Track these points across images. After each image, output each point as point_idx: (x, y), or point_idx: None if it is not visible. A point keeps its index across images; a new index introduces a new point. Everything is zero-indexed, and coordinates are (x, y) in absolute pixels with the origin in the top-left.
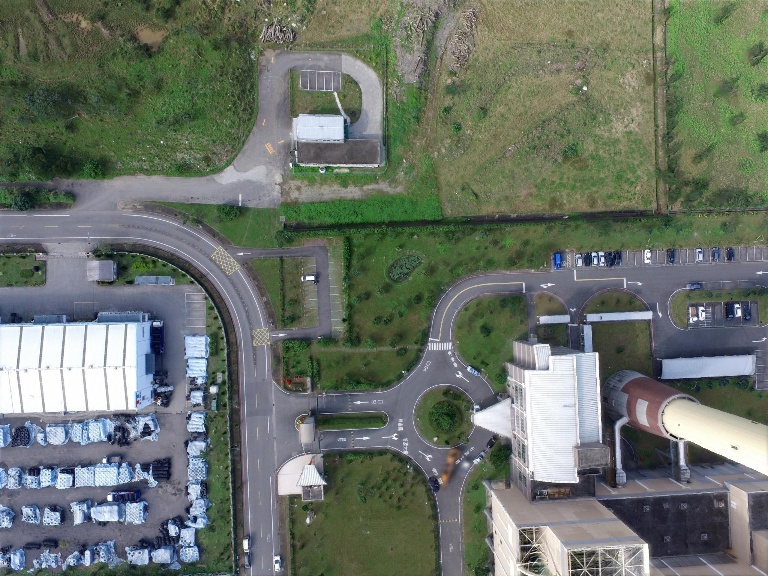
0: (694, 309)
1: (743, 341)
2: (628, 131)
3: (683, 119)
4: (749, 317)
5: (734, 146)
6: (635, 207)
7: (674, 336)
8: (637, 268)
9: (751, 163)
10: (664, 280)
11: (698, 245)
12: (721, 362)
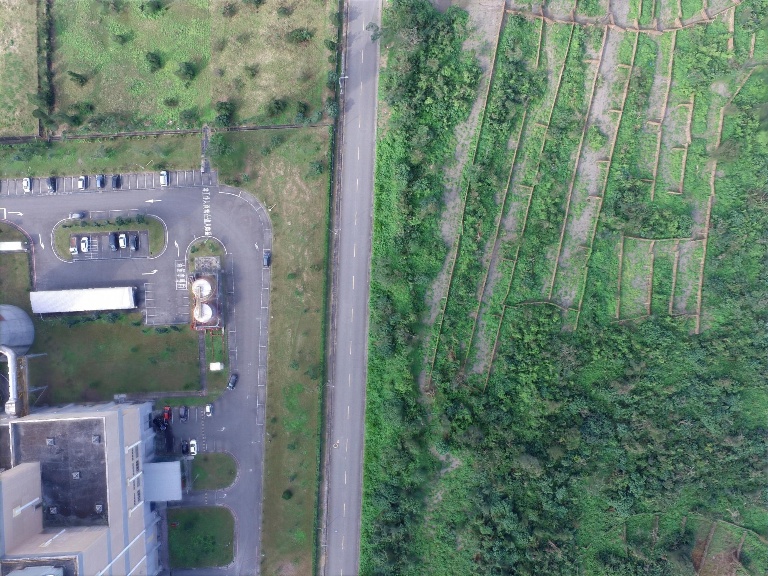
0: (75, 240)
1: (132, 274)
2: (7, 53)
3: (68, 39)
4: (134, 248)
5: (123, 67)
6: (15, 133)
7: (57, 269)
8: (18, 198)
9: (142, 84)
10: (47, 210)
11: (81, 172)
12: (94, 294)
